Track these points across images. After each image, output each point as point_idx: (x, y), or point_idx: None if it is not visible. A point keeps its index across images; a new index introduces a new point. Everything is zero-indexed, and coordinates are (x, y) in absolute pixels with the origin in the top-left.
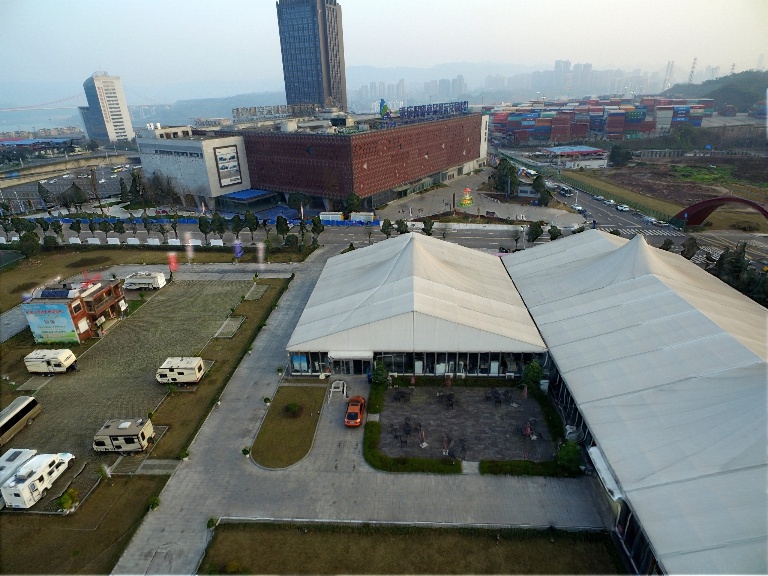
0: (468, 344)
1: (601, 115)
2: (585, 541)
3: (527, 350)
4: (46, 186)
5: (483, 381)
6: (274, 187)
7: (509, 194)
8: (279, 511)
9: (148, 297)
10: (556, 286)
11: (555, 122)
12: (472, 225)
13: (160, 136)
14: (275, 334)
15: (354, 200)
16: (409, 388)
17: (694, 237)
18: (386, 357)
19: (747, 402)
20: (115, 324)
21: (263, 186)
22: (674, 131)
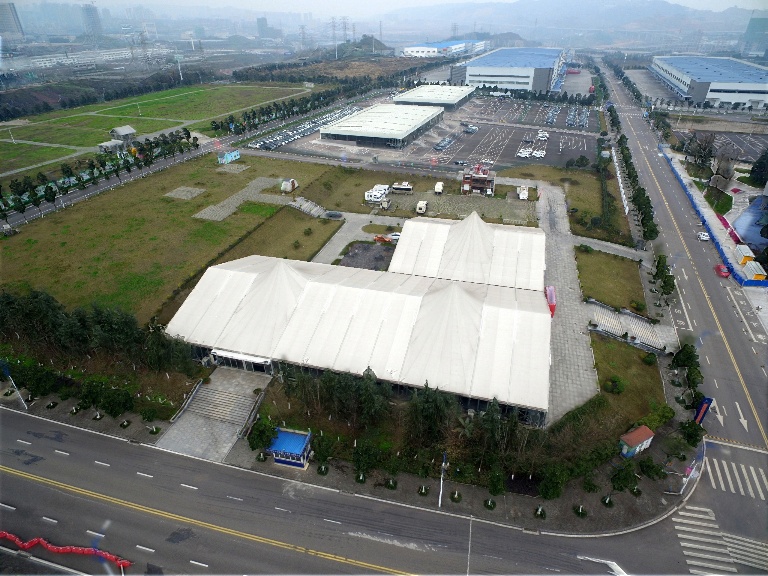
0: None
1: None
2: None
3: None
4: None
5: None
6: None
7: None
8: None
9: None
10: None
11: None
12: None
13: None
14: None
15: None
16: None
17: None
18: None
19: None
20: (478, 196)
21: None
22: None
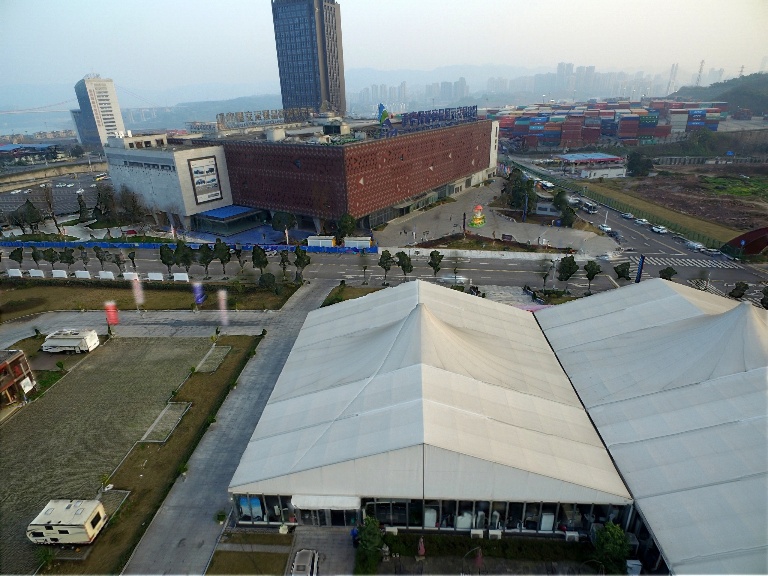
0: (508, 490)
1: (612, 119)
2: None
3: (600, 501)
4: (19, 197)
5: (531, 548)
6: (258, 204)
7: (526, 212)
8: None
9: (71, 365)
10: (623, 372)
11: (566, 127)
12: (487, 253)
13: (129, 145)
14: (226, 436)
15: (348, 222)
16: (416, 560)
17: (755, 270)
18: (380, 505)
19: None
20: (12, 414)
21: (246, 202)
22: (692, 136)
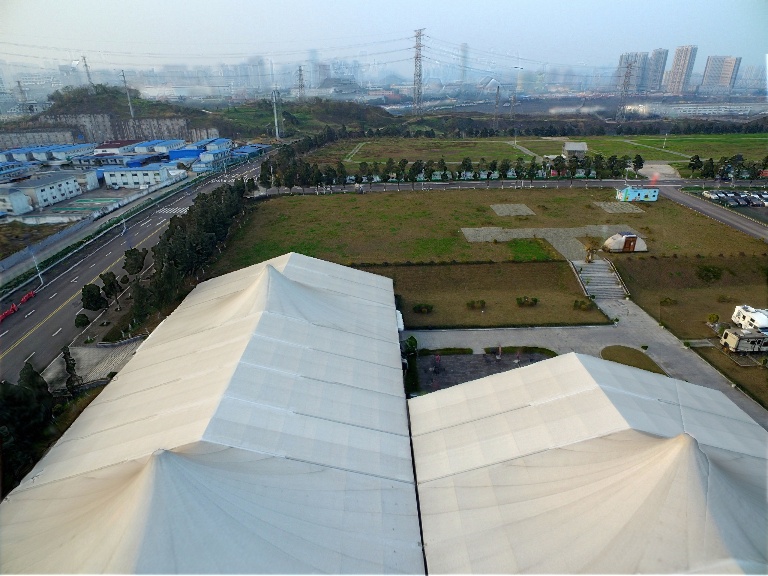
0: None
1: None
2: (414, 326)
3: None
4: None
5: None
6: None
7: None
8: (587, 330)
9: None
10: (351, 515)
11: None
12: None
13: None
14: None
15: None
16: None
17: None
18: None
19: (310, 296)
20: None
21: None
22: None
